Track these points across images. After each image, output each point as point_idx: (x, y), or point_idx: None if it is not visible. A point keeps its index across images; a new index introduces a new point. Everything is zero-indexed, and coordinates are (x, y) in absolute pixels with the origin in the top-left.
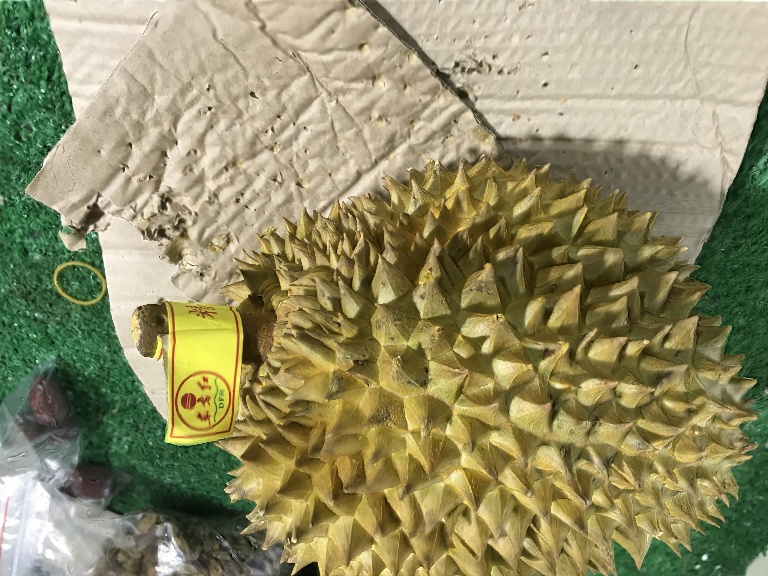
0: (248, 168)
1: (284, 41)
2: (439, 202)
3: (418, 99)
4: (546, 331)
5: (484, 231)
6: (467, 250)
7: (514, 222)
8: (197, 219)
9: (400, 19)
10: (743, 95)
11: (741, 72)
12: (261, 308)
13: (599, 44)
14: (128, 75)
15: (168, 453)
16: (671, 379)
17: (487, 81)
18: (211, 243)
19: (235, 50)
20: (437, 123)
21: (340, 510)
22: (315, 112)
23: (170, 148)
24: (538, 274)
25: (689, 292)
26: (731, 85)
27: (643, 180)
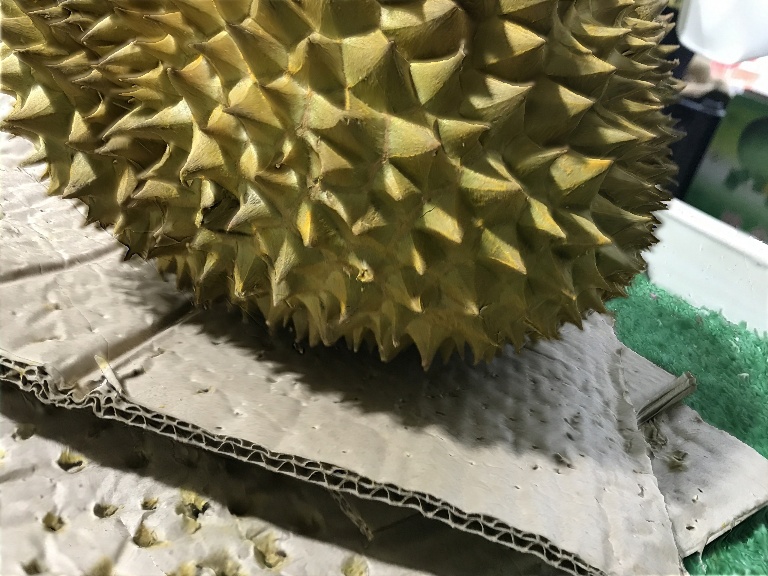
0: None
1: (7, 159)
2: None
3: None
4: None
5: None
6: None
7: None
8: None
9: None
10: None
11: None
12: None
13: None
14: None
15: None
16: None
17: None
18: None
19: None
20: None
21: None
22: None
23: None
24: None
25: None
26: None
27: None
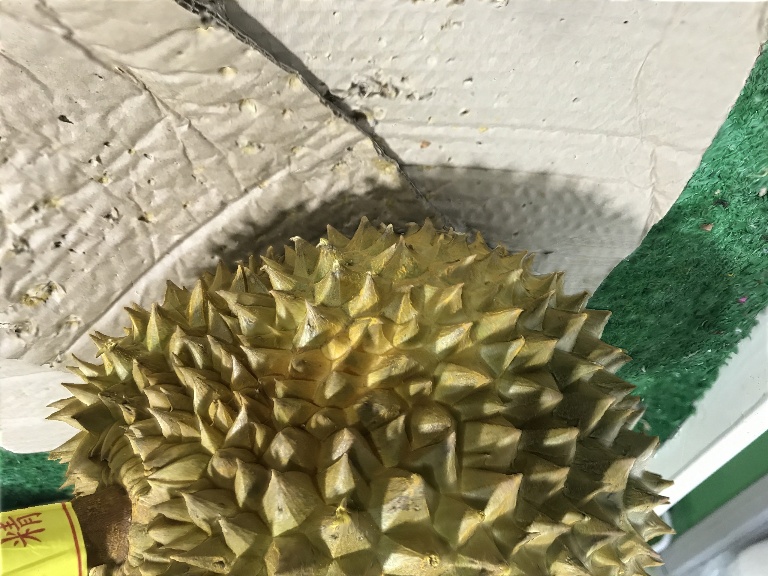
0: (68, 205)
1: (104, 54)
2: (341, 326)
3: (302, 126)
4: (481, 532)
5: (402, 381)
6: (383, 422)
7: (437, 360)
8: (0, 273)
9: (277, 32)
10: (689, 141)
11: (692, 118)
12: (107, 471)
13: (536, 73)
14: None
15: (4, 461)
16: (606, 541)
17: (392, 105)
18: (26, 295)
19: (27, 64)
20: (326, 151)
21: None
22: (159, 137)
23: None
24: (466, 430)
25: (616, 391)
26: (678, 129)
27: (564, 215)
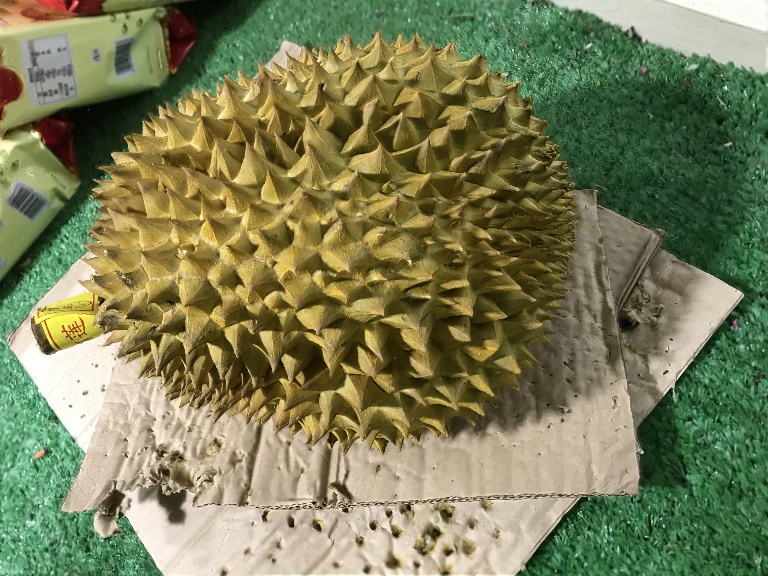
0: None
1: None
2: None
3: None
4: None
5: None
6: None
7: None
8: (186, 445)
9: None
10: None
11: None
12: None
13: None
14: (109, 404)
15: None
16: None
17: None
18: None
19: None
20: None
21: (126, 217)
22: None
23: (152, 425)
24: None
25: None
26: None
27: None
